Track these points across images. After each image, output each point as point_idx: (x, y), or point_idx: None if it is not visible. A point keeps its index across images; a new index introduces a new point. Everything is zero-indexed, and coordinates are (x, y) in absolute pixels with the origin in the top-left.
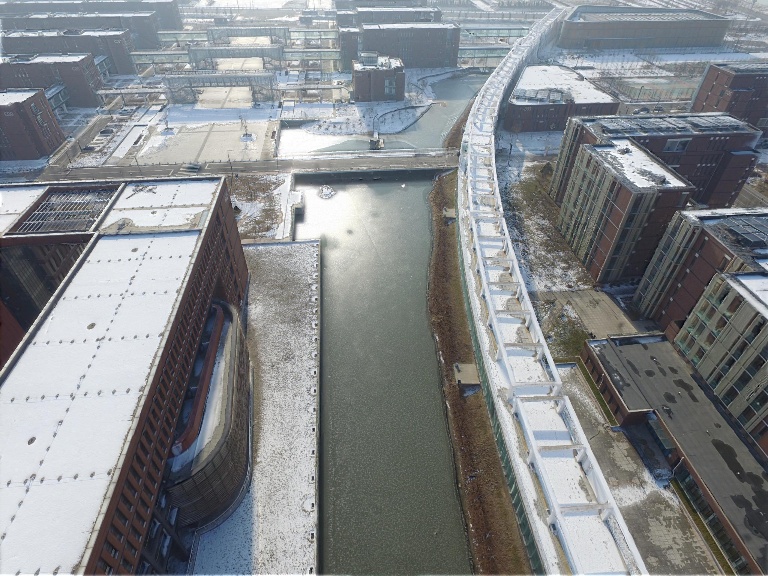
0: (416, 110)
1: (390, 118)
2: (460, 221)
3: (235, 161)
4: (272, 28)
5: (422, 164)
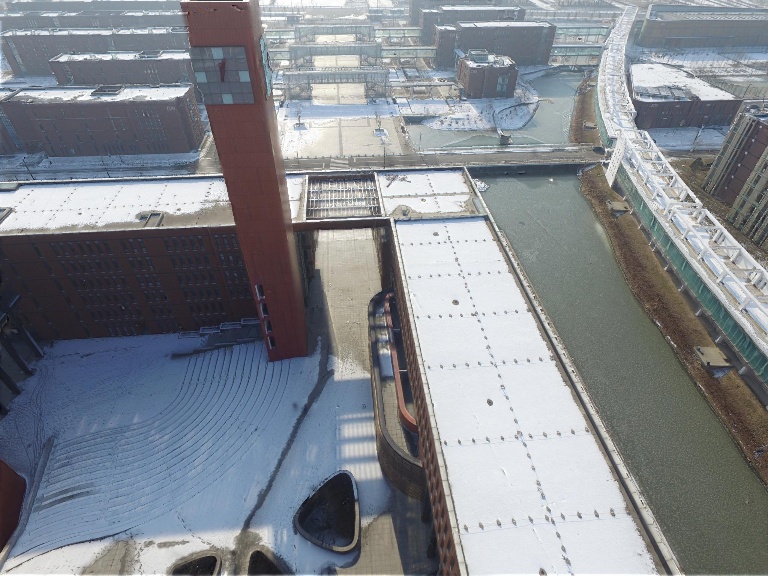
0: (528, 107)
1: (508, 114)
2: (655, 212)
3: (380, 155)
4: (358, 26)
5: (564, 159)
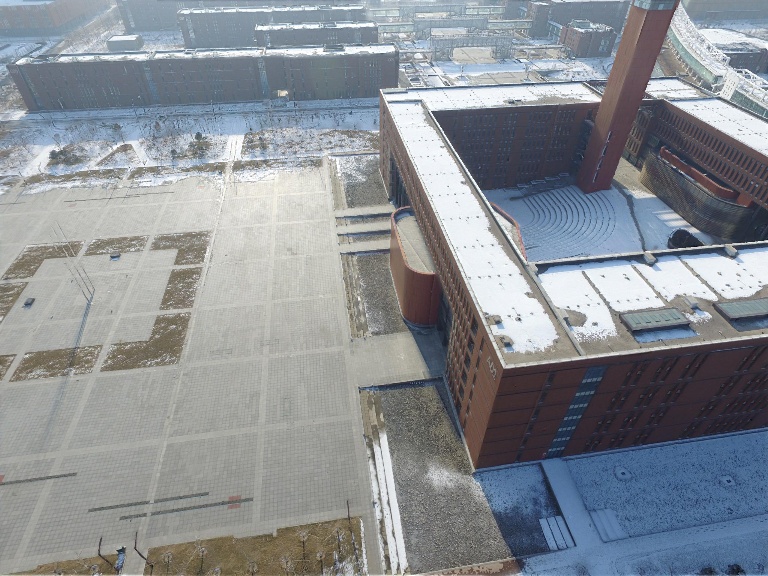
0: None
1: None
2: None
3: None
4: (453, 5)
5: None
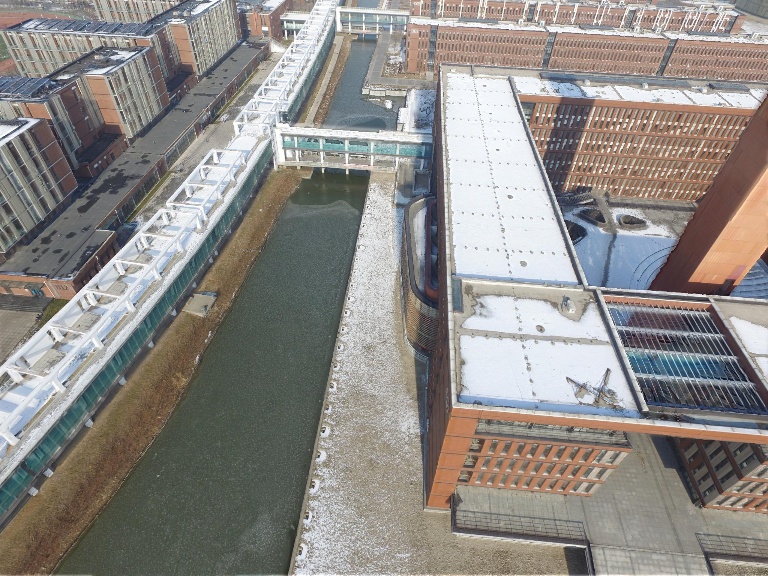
0: None
1: None
2: (7, 472)
3: None
4: None
5: None
